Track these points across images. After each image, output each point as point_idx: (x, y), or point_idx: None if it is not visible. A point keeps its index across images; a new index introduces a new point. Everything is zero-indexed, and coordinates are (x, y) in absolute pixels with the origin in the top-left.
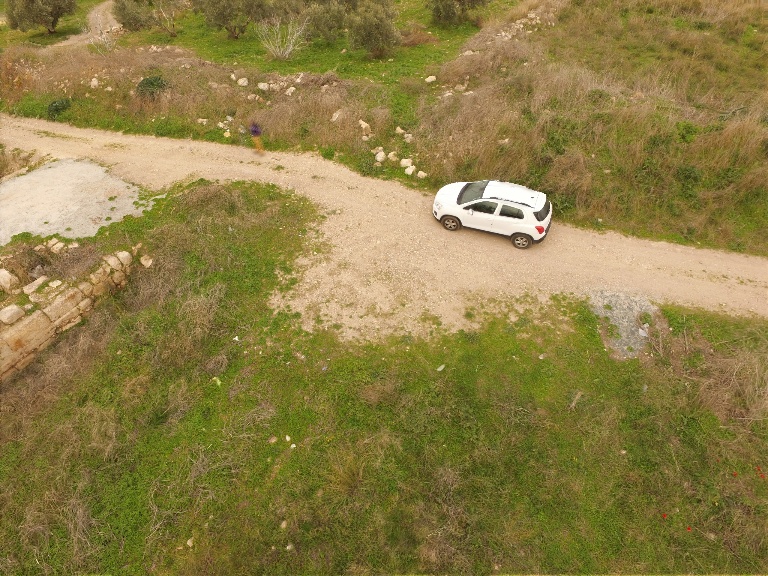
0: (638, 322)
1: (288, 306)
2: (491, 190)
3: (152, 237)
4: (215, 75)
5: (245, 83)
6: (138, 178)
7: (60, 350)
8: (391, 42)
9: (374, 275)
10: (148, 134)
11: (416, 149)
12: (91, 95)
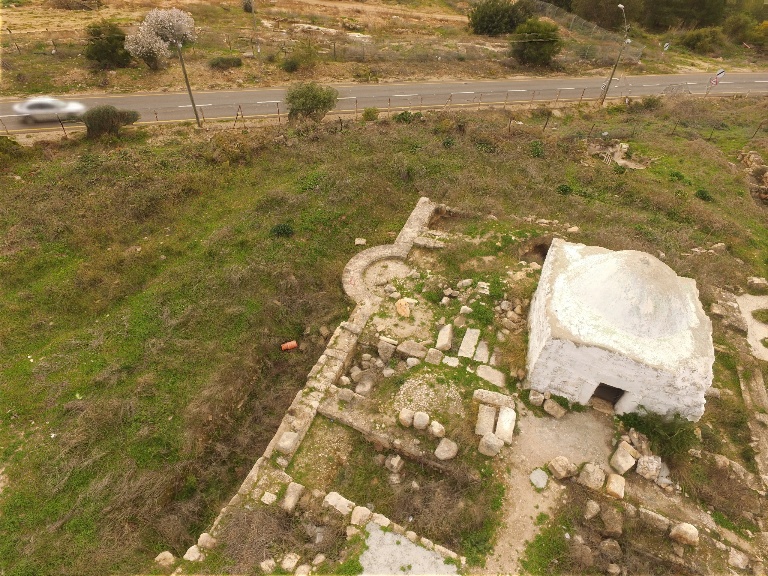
0: None
1: None
2: None
3: (137, 569)
4: None
5: None
6: None
7: None
8: None
9: None
10: None
11: None
12: None
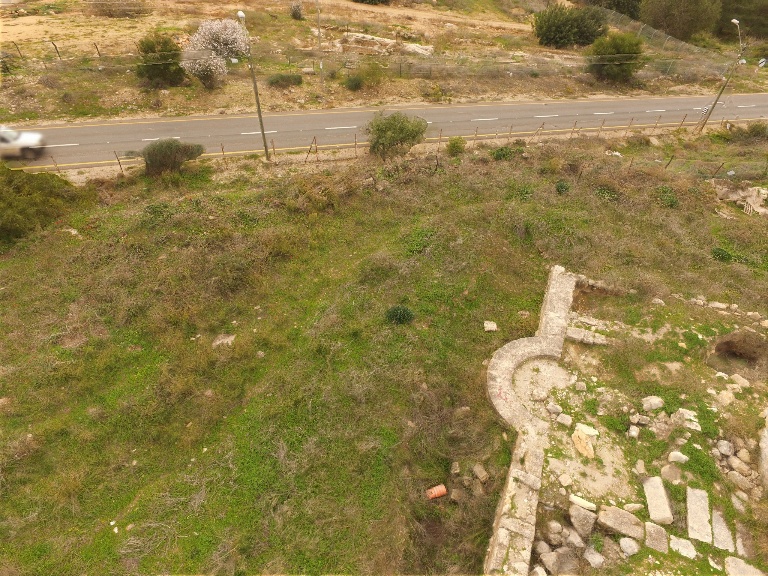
0: None
1: None
2: None
3: None
4: None
5: None
6: None
7: None
8: None
9: None
10: None
11: None
12: None
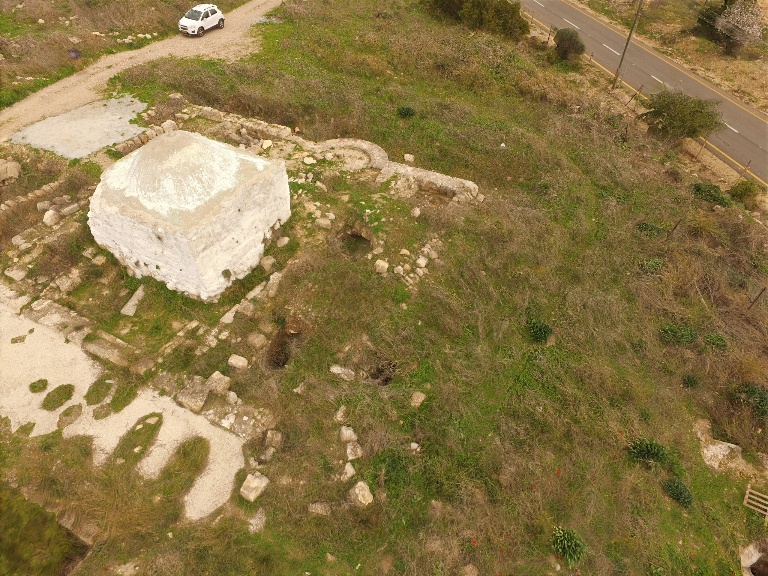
0: (269, 19)
1: (235, 60)
2: (199, 9)
3: None
4: None
5: None
6: None
7: None
8: None
9: (224, 48)
10: (1, 110)
11: (129, 33)
12: None
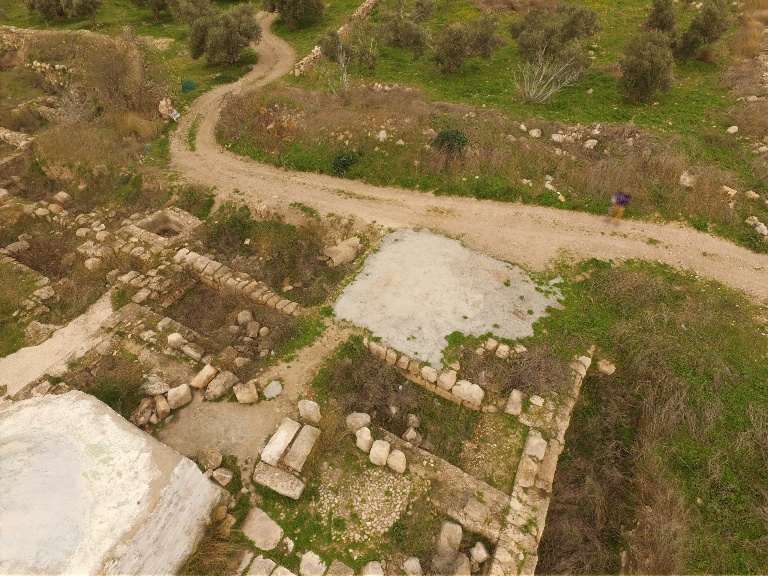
0: None
1: None
2: None
3: (621, 341)
4: (504, 125)
5: (539, 134)
6: (506, 254)
7: (589, 487)
8: (670, 86)
9: None
10: (467, 196)
11: None
12: (381, 149)
